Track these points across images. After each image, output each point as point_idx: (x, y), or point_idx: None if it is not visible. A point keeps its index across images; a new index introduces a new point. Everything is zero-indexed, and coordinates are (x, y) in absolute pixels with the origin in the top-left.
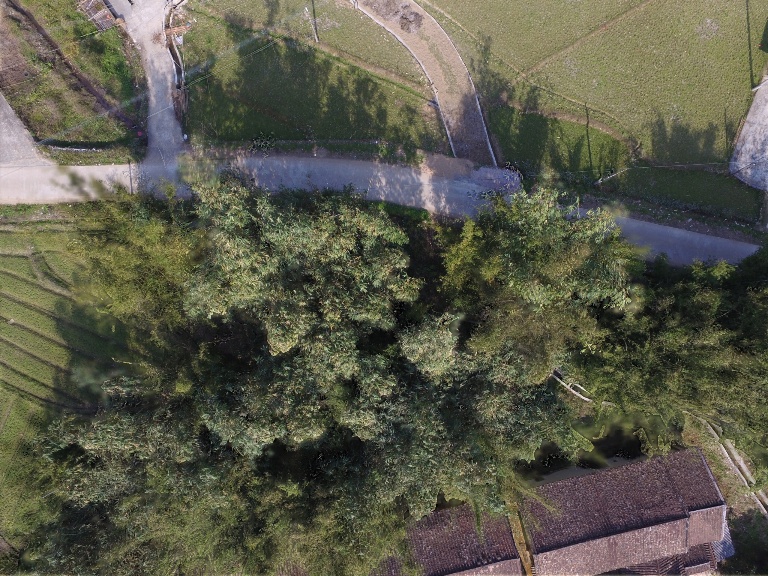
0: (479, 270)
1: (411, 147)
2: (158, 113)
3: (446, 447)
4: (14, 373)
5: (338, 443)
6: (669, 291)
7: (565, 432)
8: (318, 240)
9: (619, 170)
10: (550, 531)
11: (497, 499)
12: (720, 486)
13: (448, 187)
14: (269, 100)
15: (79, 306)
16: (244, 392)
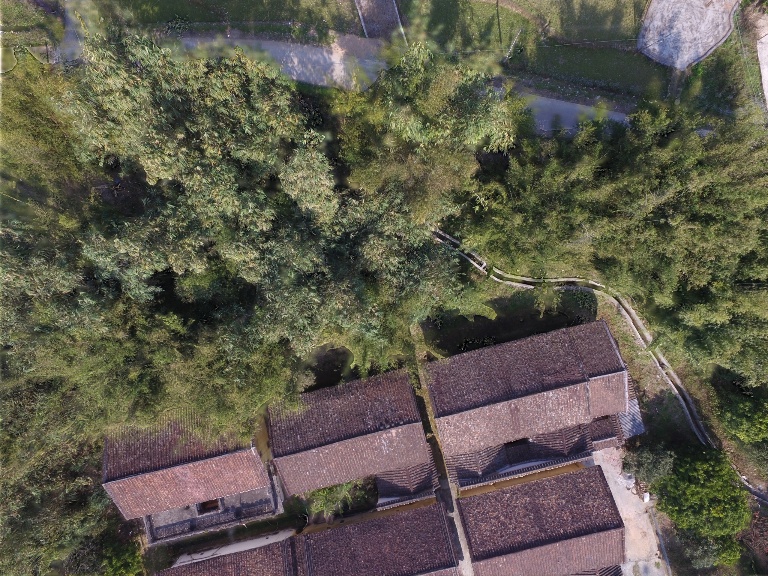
0: (368, 120)
1: (323, 28)
2: None
3: (331, 288)
4: None
5: (232, 294)
6: (552, 137)
7: (449, 276)
8: (198, 76)
9: (528, 49)
10: (453, 397)
11: (369, 324)
12: (633, 368)
13: (359, 66)
14: None
15: None
16: (128, 228)
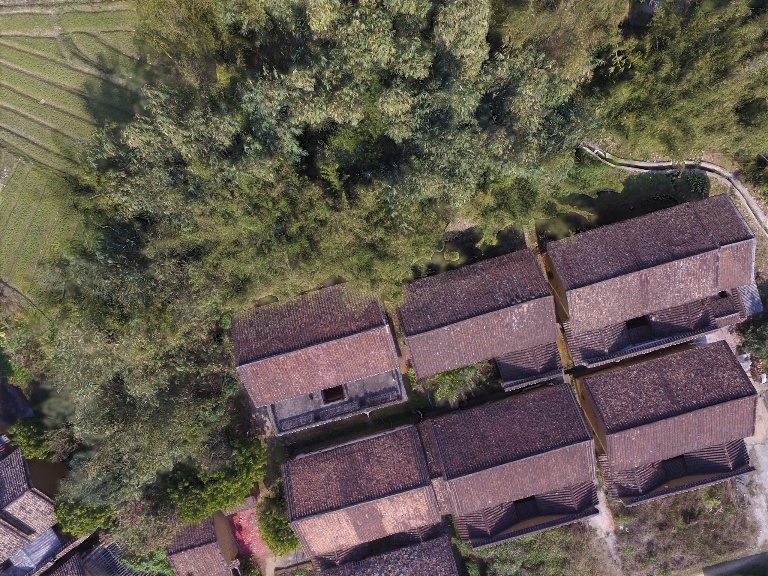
0: None
1: None
2: None
3: (482, 141)
4: (47, 152)
5: (374, 159)
6: None
7: (599, 127)
8: None
9: None
10: (582, 271)
11: (537, 162)
12: None
13: None
14: None
15: (108, 84)
16: (283, 81)
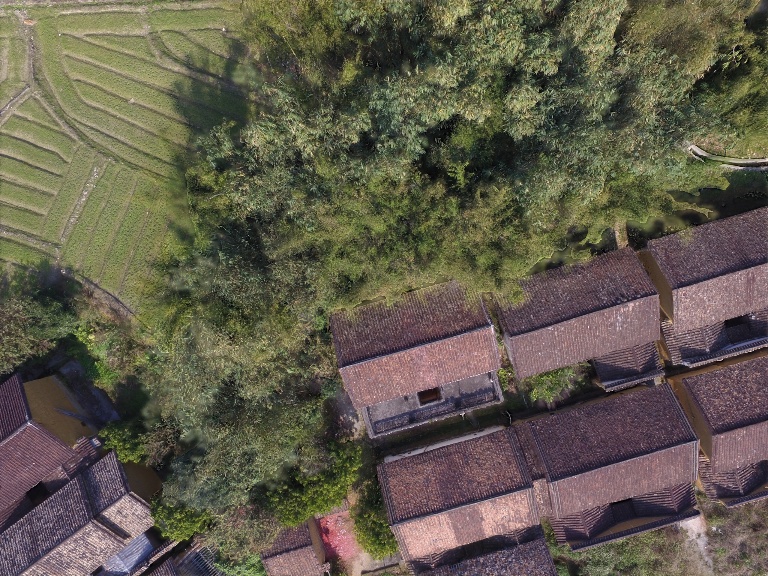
0: None
1: None
2: None
3: (607, 138)
4: (137, 152)
5: (489, 157)
6: None
7: (723, 123)
8: None
9: None
10: (688, 269)
11: None
12: None
13: None
14: None
15: (199, 82)
16: (410, 77)
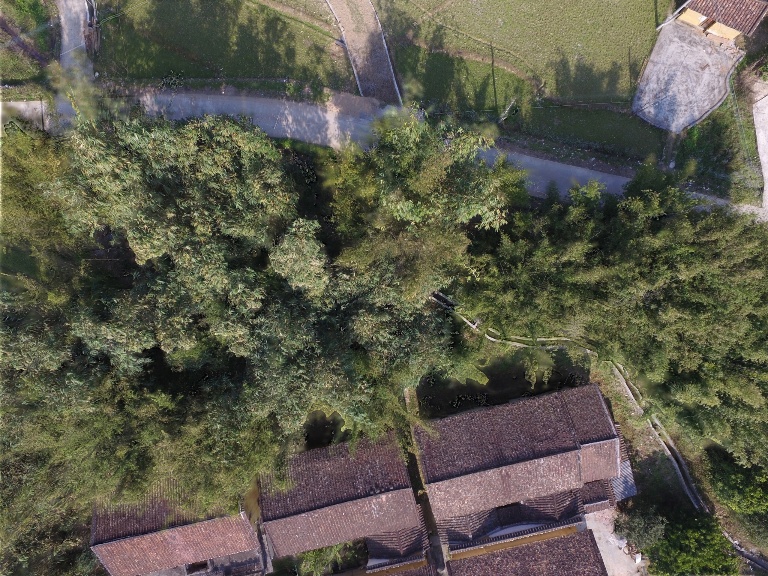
0: (360, 193)
1: (318, 85)
2: (70, 51)
3: (320, 364)
4: None
5: (222, 364)
6: (545, 213)
7: (440, 352)
8: (189, 154)
9: (524, 109)
10: (444, 462)
11: (357, 408)
12: (626, 428)
13: (353, 125)
14: (179, 39)
15: None
16: (117, 304)
